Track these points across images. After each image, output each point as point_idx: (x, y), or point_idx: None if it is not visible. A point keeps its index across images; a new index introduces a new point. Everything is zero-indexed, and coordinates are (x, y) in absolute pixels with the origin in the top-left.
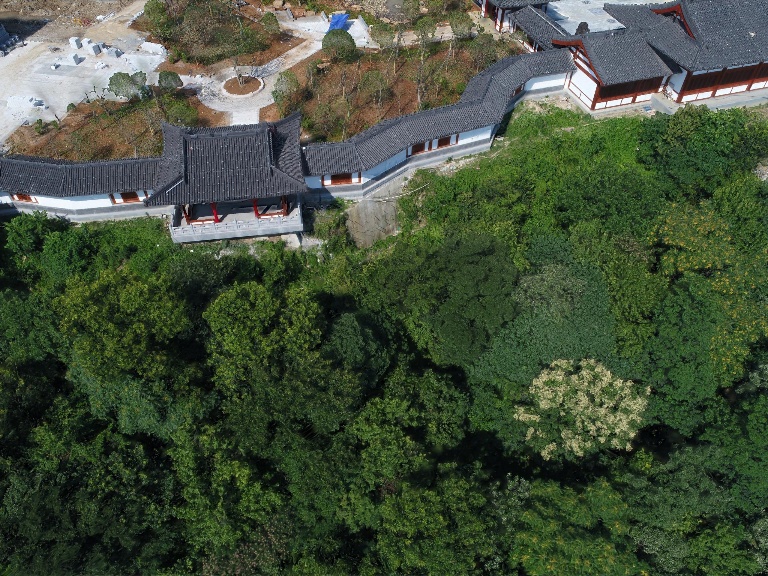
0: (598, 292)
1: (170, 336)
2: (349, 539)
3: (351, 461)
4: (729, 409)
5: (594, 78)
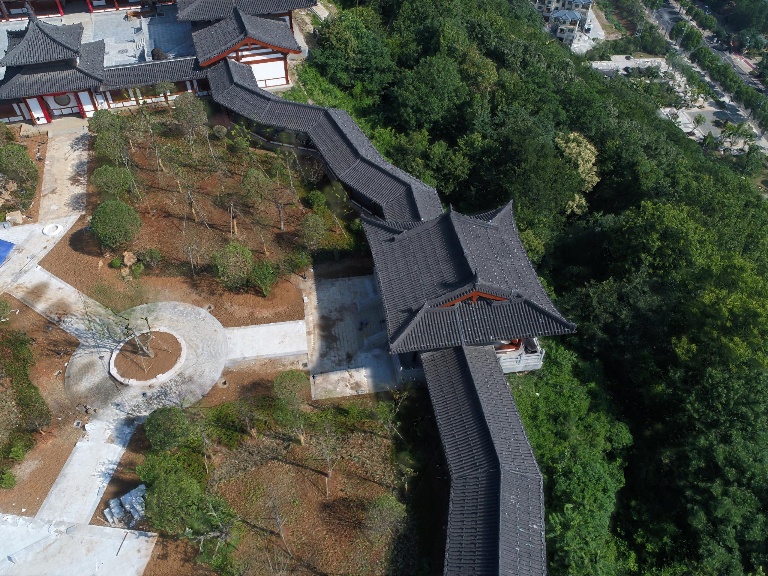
0: None
1: None
2: None
3: None
4: None
5: (277, 58)
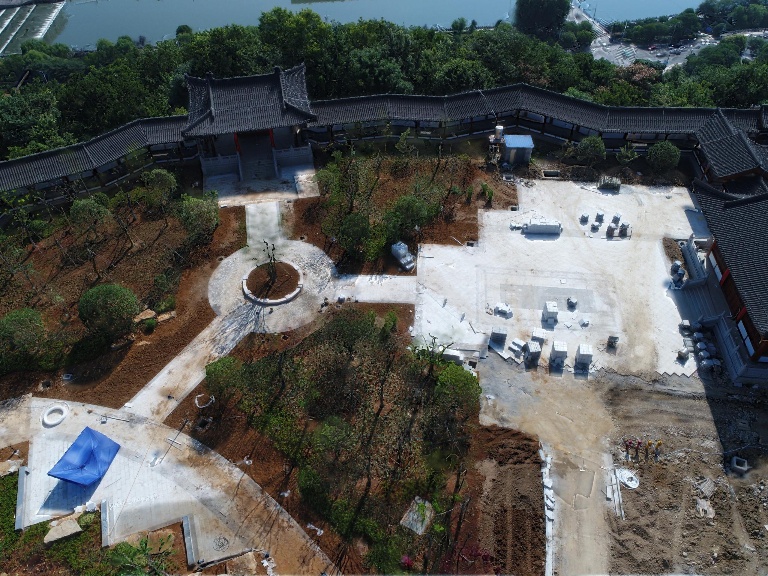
0: None
1: None
2: None
3: None
4: None
5: None
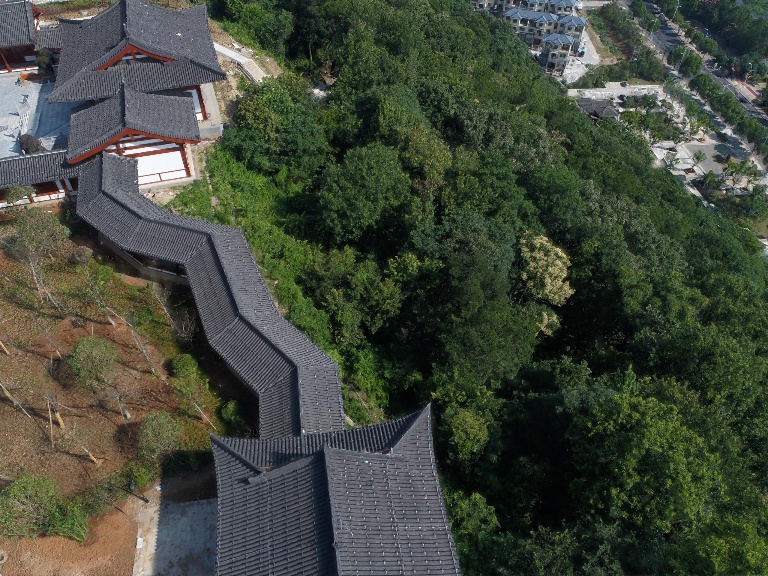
0: None
1: None
2: None
3: None
4: (530, 200)
5: (170, 149)
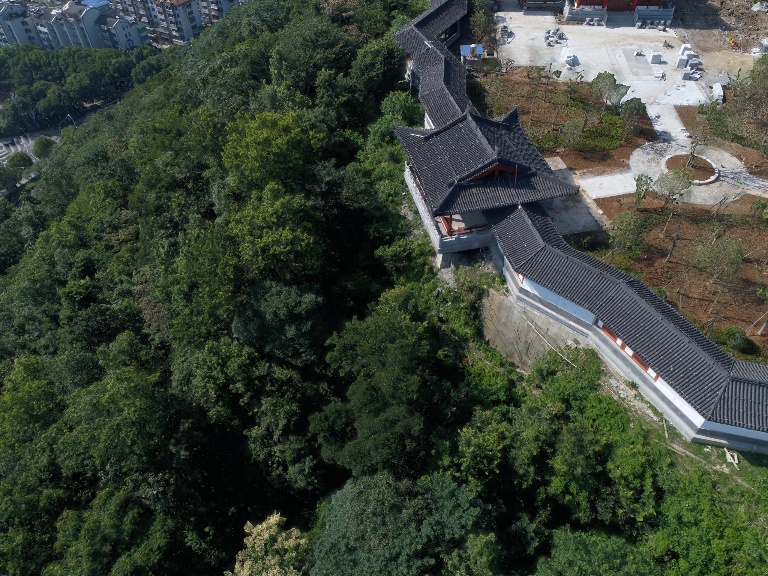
0: (374, 575)
1: (251, 176)
2: (170, 383)
3: (197, 347)
4: None
5: None
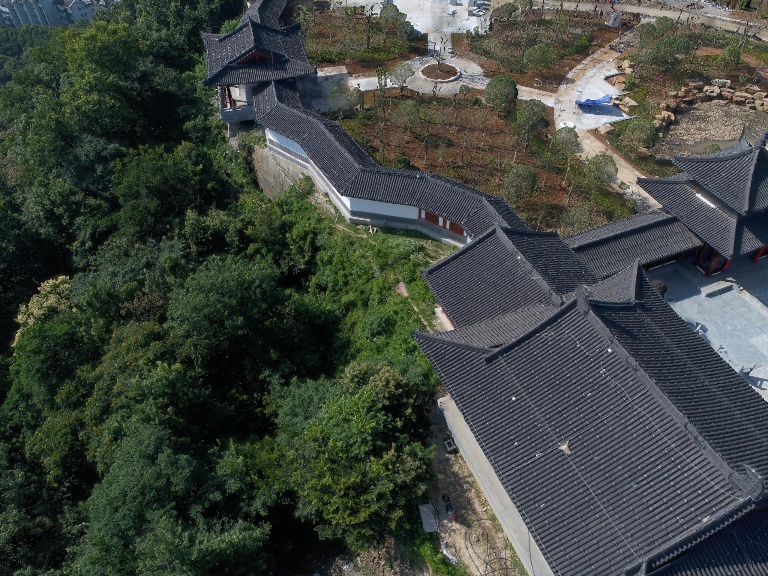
0: None
1: None
2: None
3: None
4: None
5: None
